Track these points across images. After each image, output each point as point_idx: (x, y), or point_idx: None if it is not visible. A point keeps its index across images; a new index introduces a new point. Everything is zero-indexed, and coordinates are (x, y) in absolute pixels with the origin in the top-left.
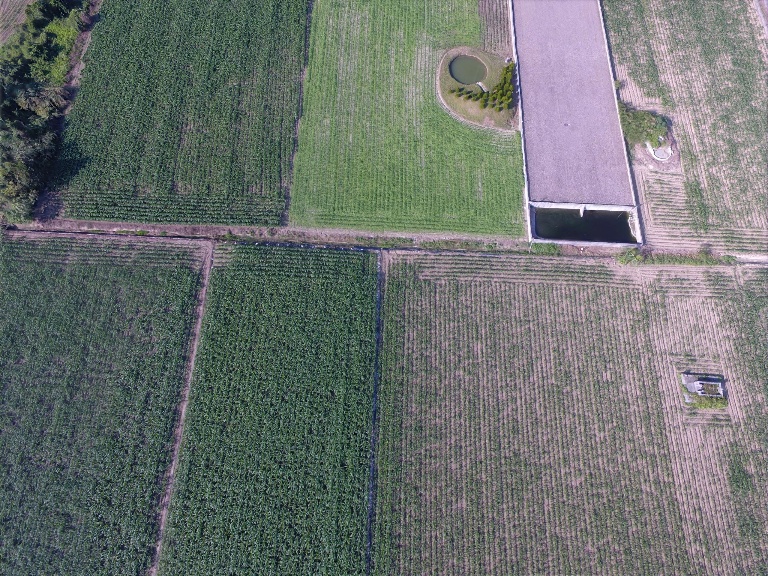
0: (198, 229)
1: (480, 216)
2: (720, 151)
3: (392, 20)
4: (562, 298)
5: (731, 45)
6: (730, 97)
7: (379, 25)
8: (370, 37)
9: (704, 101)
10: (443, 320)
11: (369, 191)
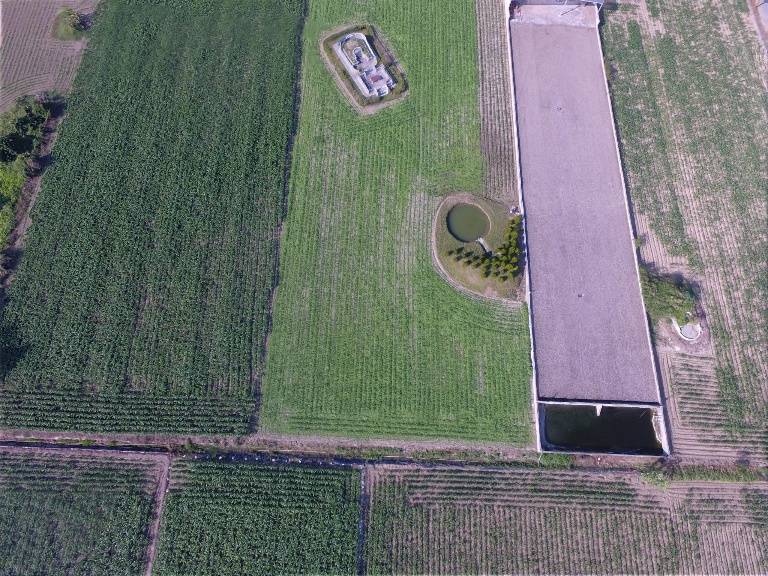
0: (153, 438)
1: (481, 417)
2: (756, 326)
3: (383, 159)
4: (576, 528)
5: (765, 189)
6: (766, 256)
7: (368, 165)
8: (357, 181)
9: (736, 261)
10: (437, 561)
11: (353, 384)
